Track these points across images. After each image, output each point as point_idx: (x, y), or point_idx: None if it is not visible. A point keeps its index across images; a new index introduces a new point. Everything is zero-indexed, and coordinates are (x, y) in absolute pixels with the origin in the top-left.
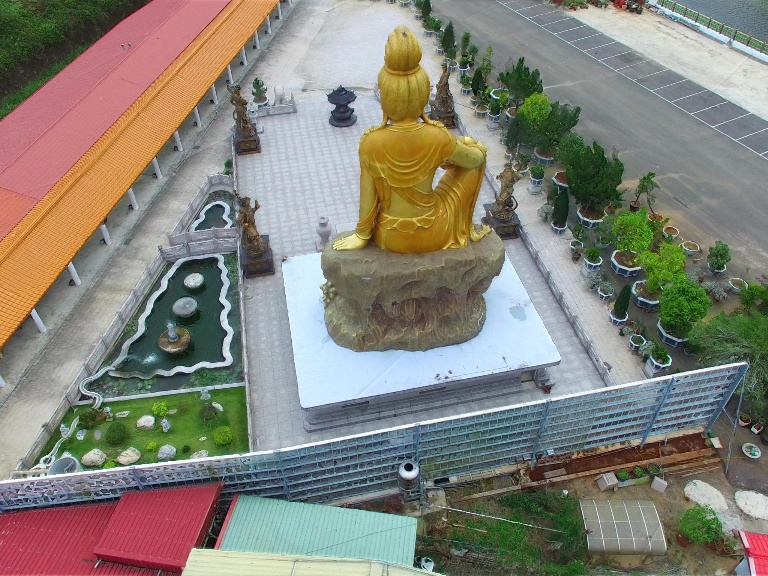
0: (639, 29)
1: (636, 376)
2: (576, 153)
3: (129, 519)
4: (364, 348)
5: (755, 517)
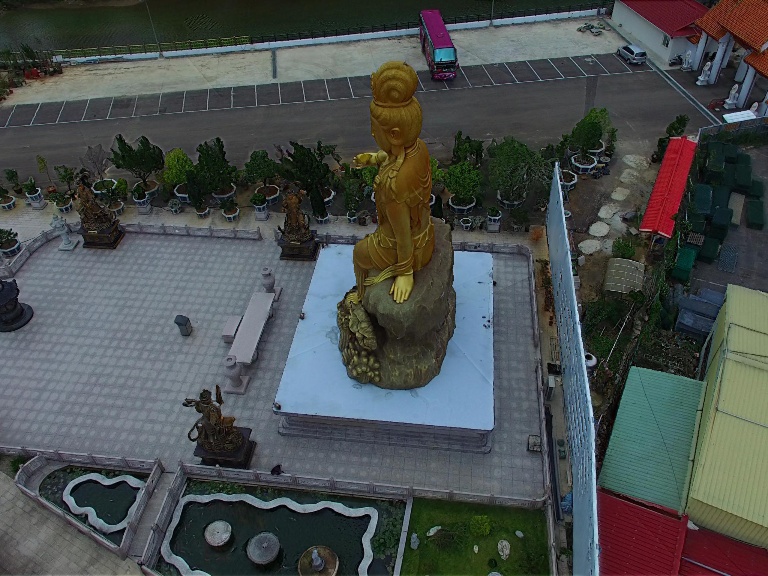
0: (86, 82)
1: (492, 237)
2: (284, 160)
3: (632, 575)
4: (439, 366)
5: (608, 233)
